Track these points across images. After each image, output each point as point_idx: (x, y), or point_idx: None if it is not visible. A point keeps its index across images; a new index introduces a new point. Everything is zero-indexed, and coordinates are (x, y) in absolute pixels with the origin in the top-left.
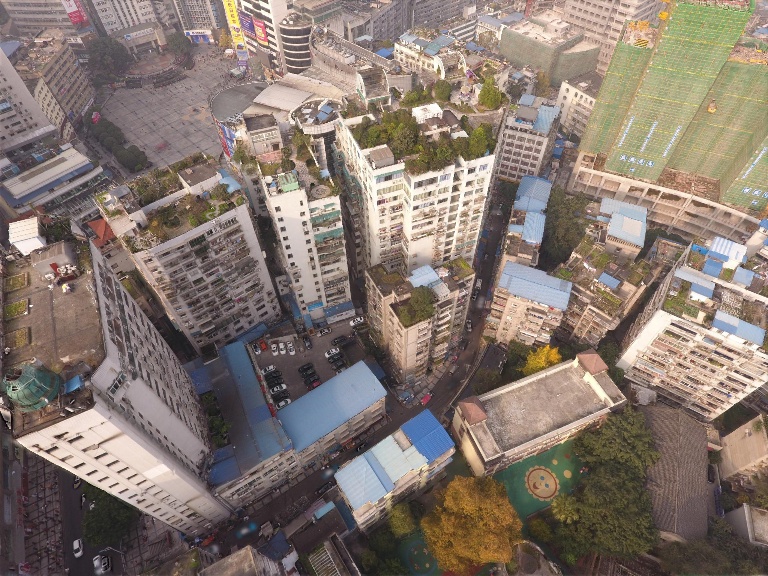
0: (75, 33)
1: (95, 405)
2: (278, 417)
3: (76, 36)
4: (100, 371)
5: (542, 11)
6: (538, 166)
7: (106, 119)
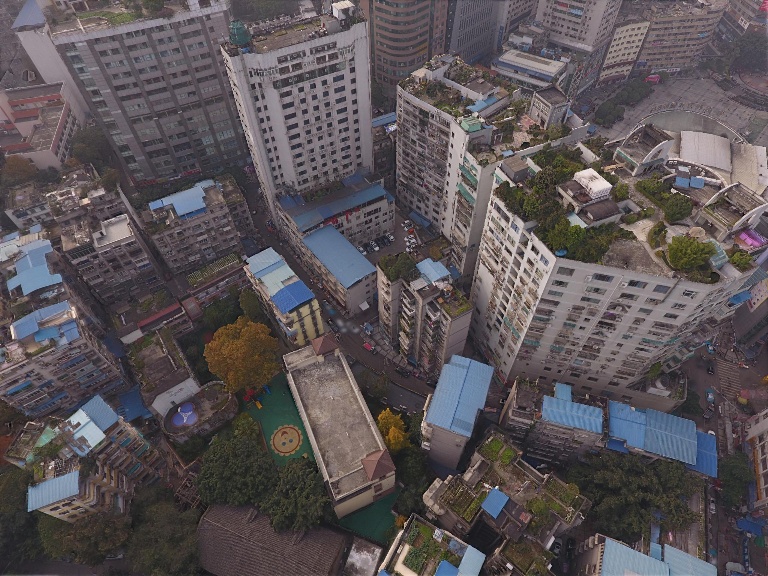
0: (752, 18)
1: (232, 57)
2: (328, 226)
3: (750, 21)
4: (253, 56)
5: None
6: None
7: (651, 83)
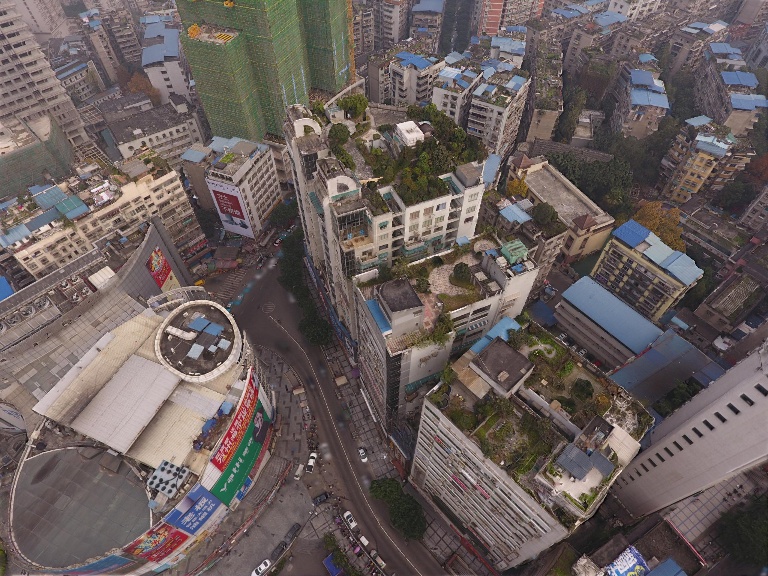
0: None
1: None
2: None
3: None
4: None
5: None
6: (277, 177)
7: None
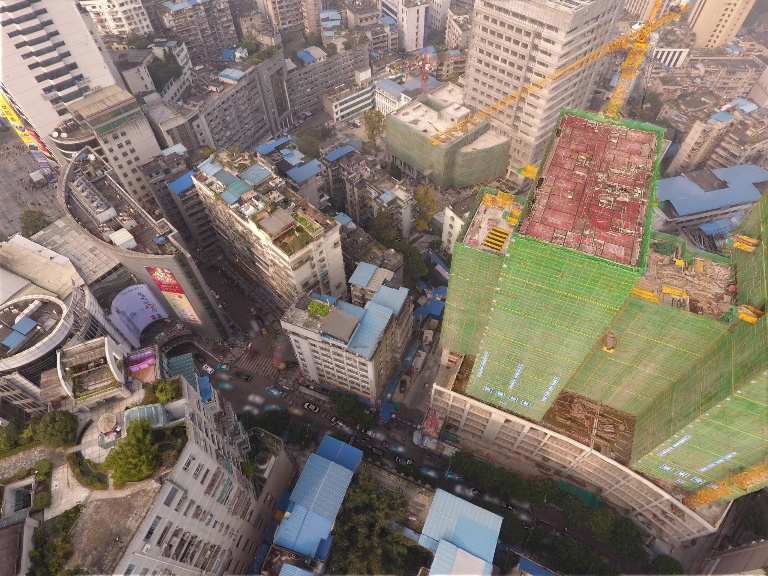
0: None
1: None
2: None
3: None
4: None
5: (442, 85)
6: (371, 384)
7: None
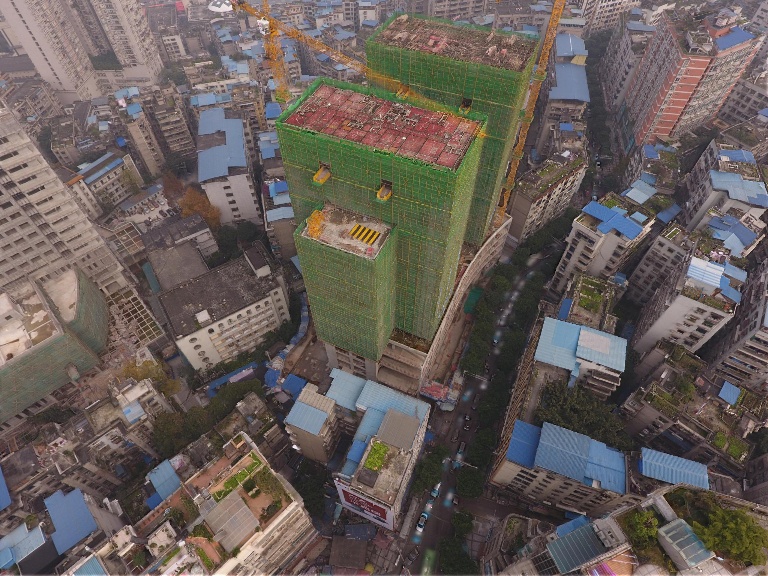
0: None
1: None
2: None
3: None
4: None
5: None
6: None
7: None
